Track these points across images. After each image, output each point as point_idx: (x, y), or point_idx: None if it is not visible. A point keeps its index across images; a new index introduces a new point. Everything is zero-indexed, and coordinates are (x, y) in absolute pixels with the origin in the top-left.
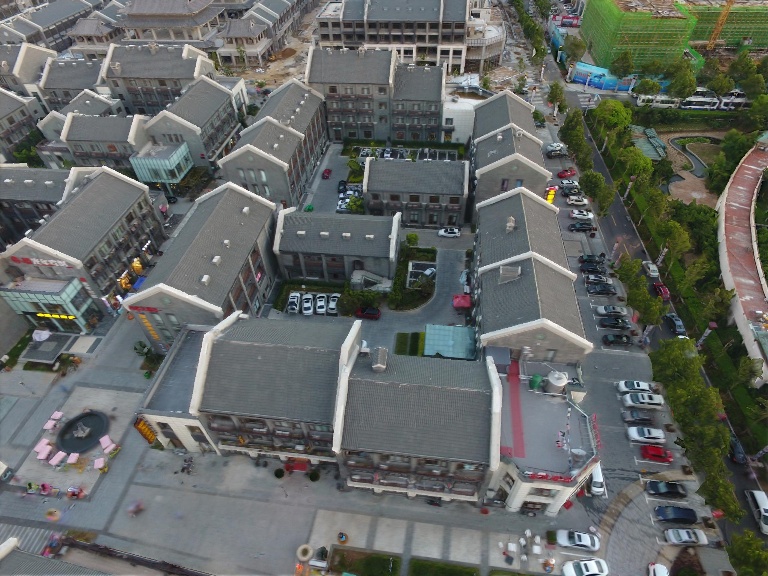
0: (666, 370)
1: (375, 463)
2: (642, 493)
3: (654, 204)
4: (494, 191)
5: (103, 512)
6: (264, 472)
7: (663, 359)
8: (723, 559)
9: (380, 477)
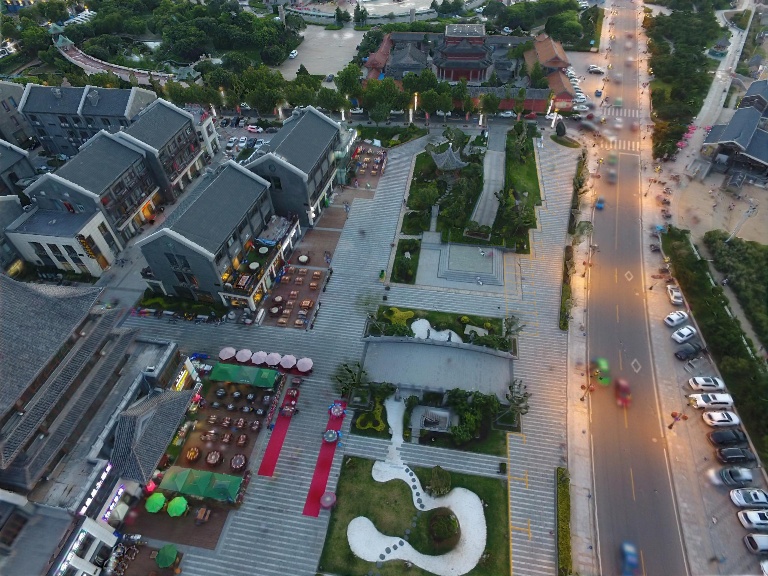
0: (178, 94)
1: (170, 156)
2: (224, 128)
3: (76, 80)
4: (4, 114)
5: (129, 295)
6: (146, 231)
7: (172, 91)
8: (254, 119)
9: (177, 170)
